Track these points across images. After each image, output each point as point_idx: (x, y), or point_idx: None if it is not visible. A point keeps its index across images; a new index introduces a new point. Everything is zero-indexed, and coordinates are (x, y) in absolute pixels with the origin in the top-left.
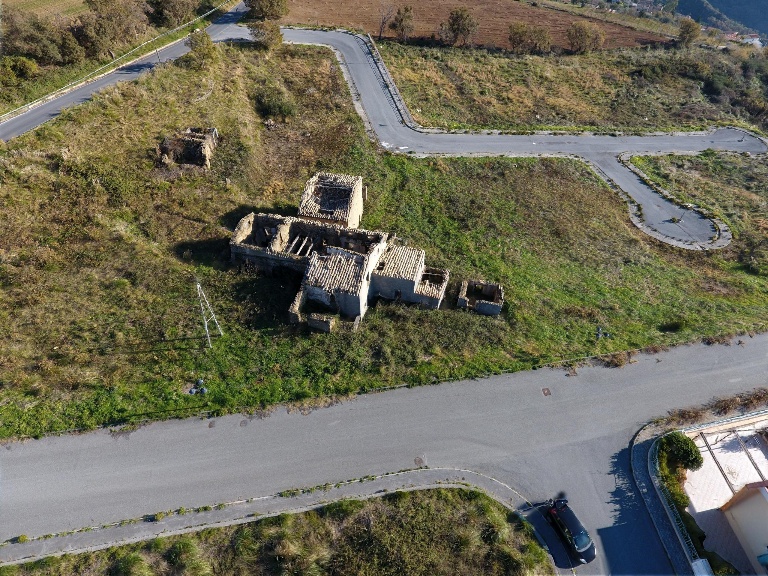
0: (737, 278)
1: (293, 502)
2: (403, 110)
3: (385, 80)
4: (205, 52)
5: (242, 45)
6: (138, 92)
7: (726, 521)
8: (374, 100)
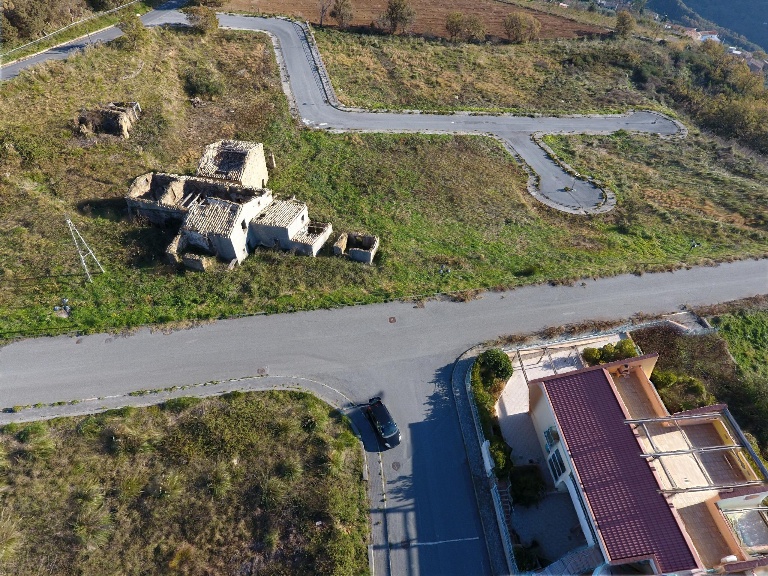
0: (605, 236)
1: (140, 400)
2: (329, 91)
3: (316, 63)
4: (135, 33)
5: (179, 29)
6: (67, 70)
7: (531, 422)
8: (302, 81)
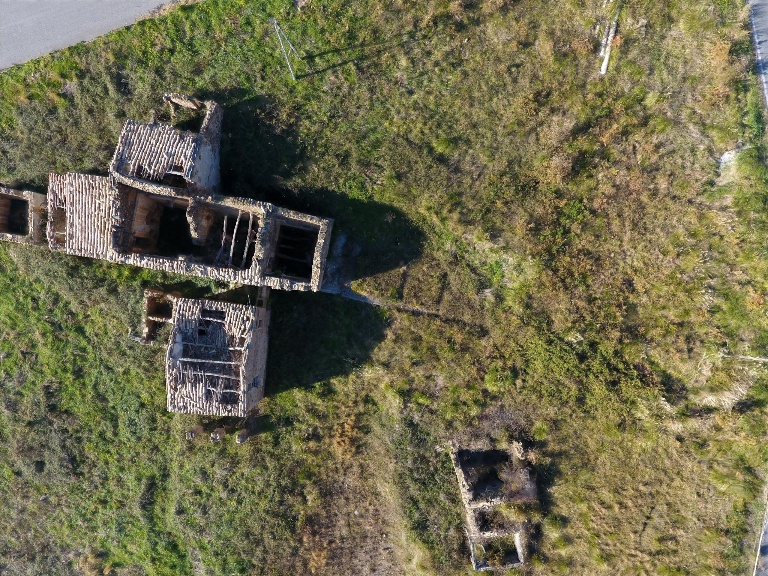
0: None
1: None
2: None
3: None
4: None
5: None
6: None
7: None
8: None
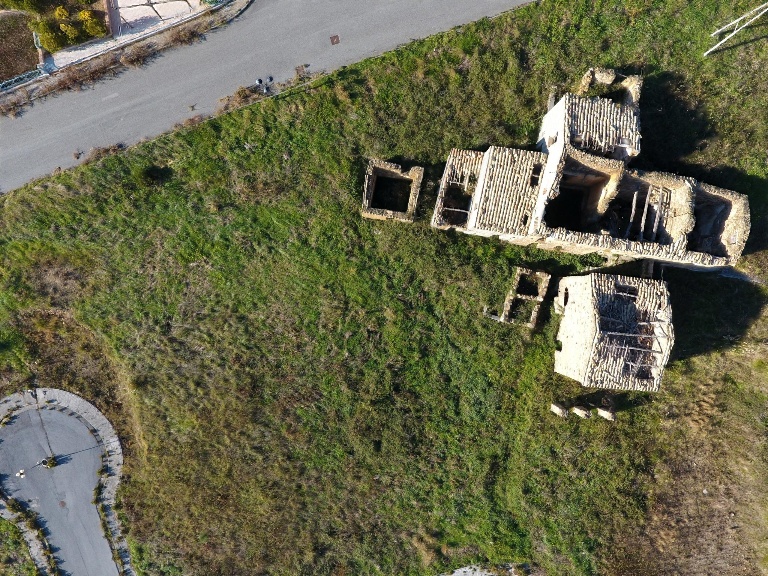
0: (18, 310)
1: None
2: None
3: None
4: None
5: None
6: None
7: None
8: None
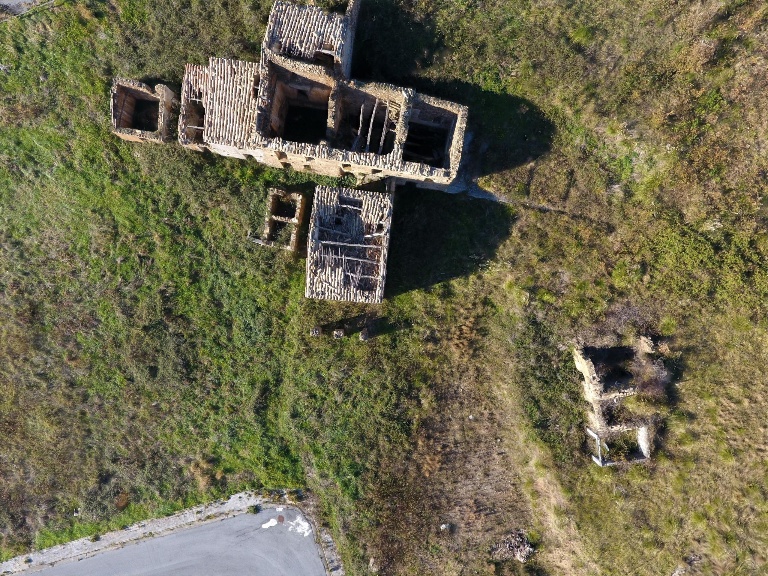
0: None
1: None
2: None
3: None
4: None
5: None
6: None
7: None
8: None
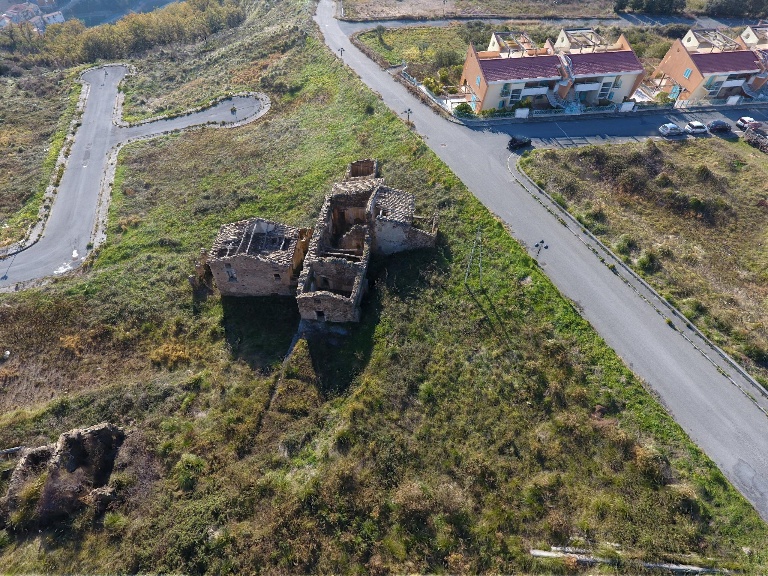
0: None
1: (567, 220)
2: None
3: None
4: None
5: None
6: None
7: None
8: None
